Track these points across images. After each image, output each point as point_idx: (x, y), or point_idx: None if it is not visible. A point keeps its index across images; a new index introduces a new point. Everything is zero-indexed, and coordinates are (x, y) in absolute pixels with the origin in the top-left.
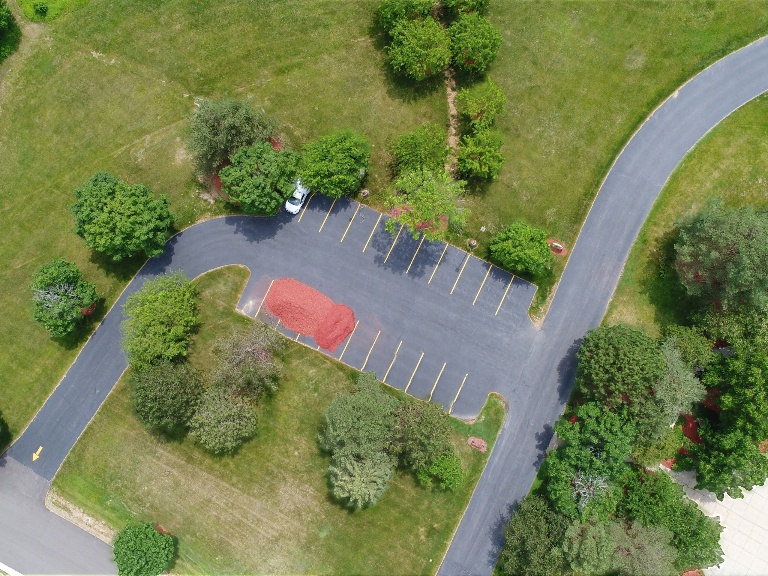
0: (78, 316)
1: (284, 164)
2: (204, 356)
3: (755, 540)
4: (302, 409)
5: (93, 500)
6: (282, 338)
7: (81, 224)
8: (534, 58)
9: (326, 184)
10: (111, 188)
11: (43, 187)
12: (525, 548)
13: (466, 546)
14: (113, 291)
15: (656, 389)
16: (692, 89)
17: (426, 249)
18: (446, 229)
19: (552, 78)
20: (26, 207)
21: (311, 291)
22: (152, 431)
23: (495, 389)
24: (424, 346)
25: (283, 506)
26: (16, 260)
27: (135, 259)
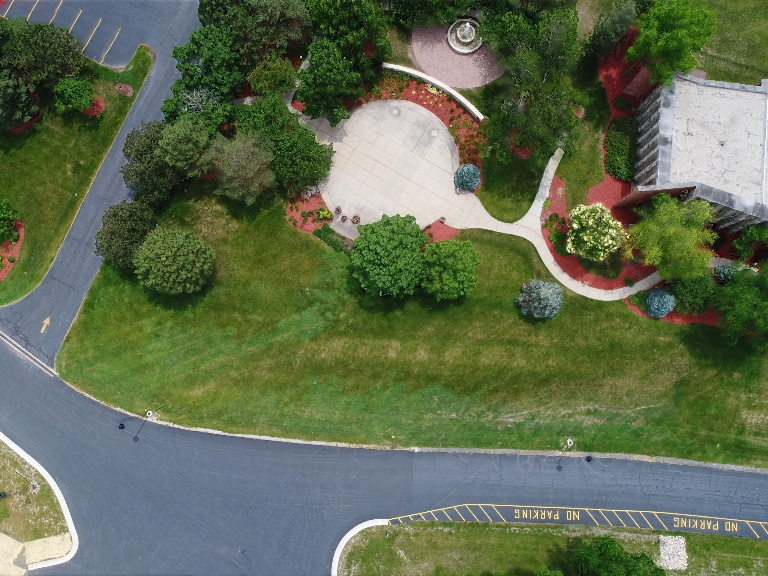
0: None
1: None
2: None
3: (376, 175)
4: None
5: None
6: None
7: None
8: None
9: None
10: None
11: None
12: None
13: (108, 181)
14: None
15: None
16: None
17: None
18: None
19: None
20: None
21: None
22: None
23: (144, 42)
24: (82, 4)
25: None
26: None
27: None
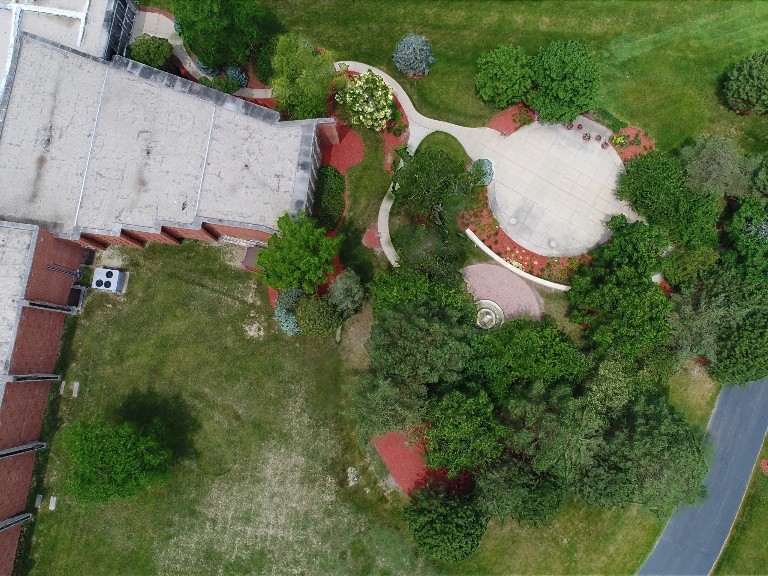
0: None
1: None
2: None
3: (570, 180)
4: None
5: None
6: None
7: None
8: None
9: None
10: None
11: None
12: None
13: None
14: None
15: None
16: None
17: None
18: None
19: None
20: None
21: None
22: None
23: None
24: None
25: None
26: None
27: None
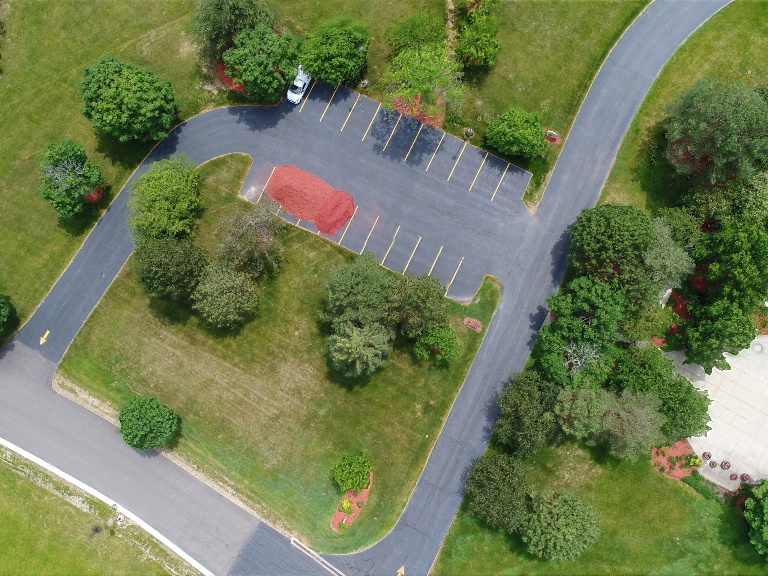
0: (85, 194)
1: (286, 45)
2: (207, 239)
3: (742, 417)
4: (302, 290)
5: (99, 382)
6: (283, 223)
7: (89, 103)
8: None
9: (327, 68)
10: (118, 66)
11: (51, 81)
12: (518, 414)
13: (461, 422)
14: (119, 179)
15: (646, 256)
16: None
17: (424, 138)
18: (443, 119)
19: None
20: (34, 100)
21: (312, 177)
22: (156, 314)
23: (490, 272)
24: (421, 231)
25: (284, 385)
26: (24, 151)
27: (140, 148)
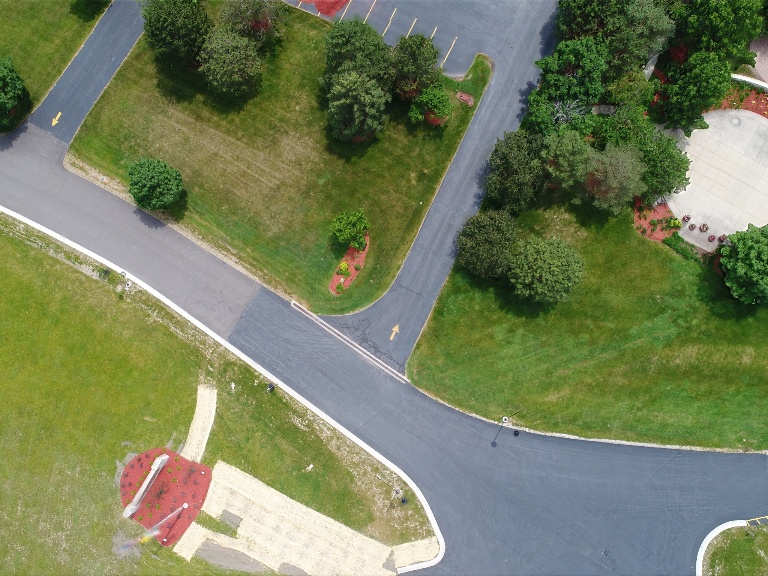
0: None
1: None
2: (213, 19)
3: (720, 184)
4: (303, 66)
5: (108, 161)
6: (285, 5)
7: None
8: None
9: None
10: None
11: None
12: (507, 164)
13: (454, 189)
14: None
15: (628, 7)
16: None
17: None
18: None
19: None
20: None
21: None
22: (164, 93)
23: (482, 50)
24: (417, 12)
25: (285, 157)
26: None
27: None
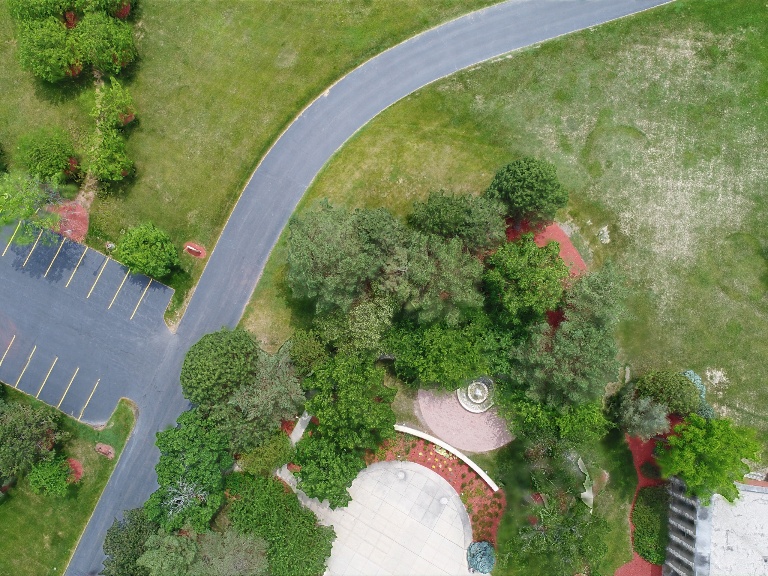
0: None
1: None
2: None
3: (381, 550)
4: None
5: None
6: None
7: None
8: (185, 58)
9: None
10: None
11: None
12: None
13: (90, 554)
14: None
15: (234, 395)
16: (343, 88)
17: (65, 252)
18: (86, 232)
19: (202, 78)
20: None
21: None
22: None
23: (126, 394)
24: (57, 351)
25: None
26: None
27: None
